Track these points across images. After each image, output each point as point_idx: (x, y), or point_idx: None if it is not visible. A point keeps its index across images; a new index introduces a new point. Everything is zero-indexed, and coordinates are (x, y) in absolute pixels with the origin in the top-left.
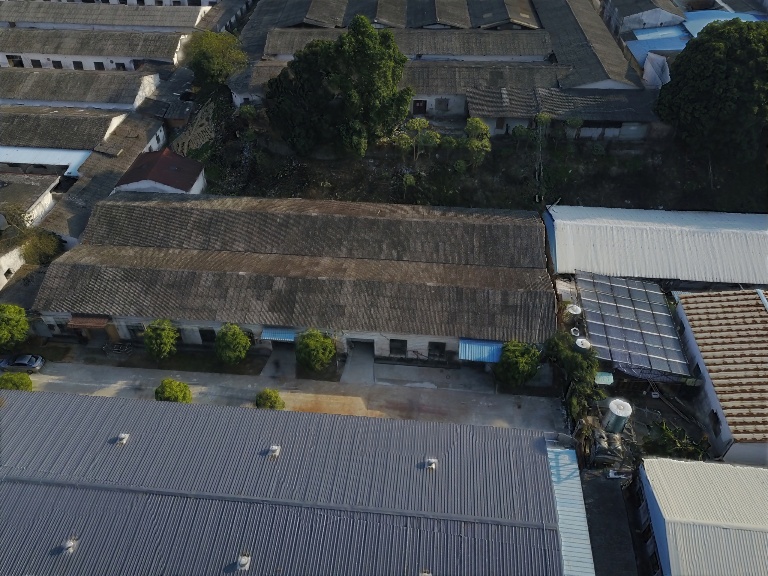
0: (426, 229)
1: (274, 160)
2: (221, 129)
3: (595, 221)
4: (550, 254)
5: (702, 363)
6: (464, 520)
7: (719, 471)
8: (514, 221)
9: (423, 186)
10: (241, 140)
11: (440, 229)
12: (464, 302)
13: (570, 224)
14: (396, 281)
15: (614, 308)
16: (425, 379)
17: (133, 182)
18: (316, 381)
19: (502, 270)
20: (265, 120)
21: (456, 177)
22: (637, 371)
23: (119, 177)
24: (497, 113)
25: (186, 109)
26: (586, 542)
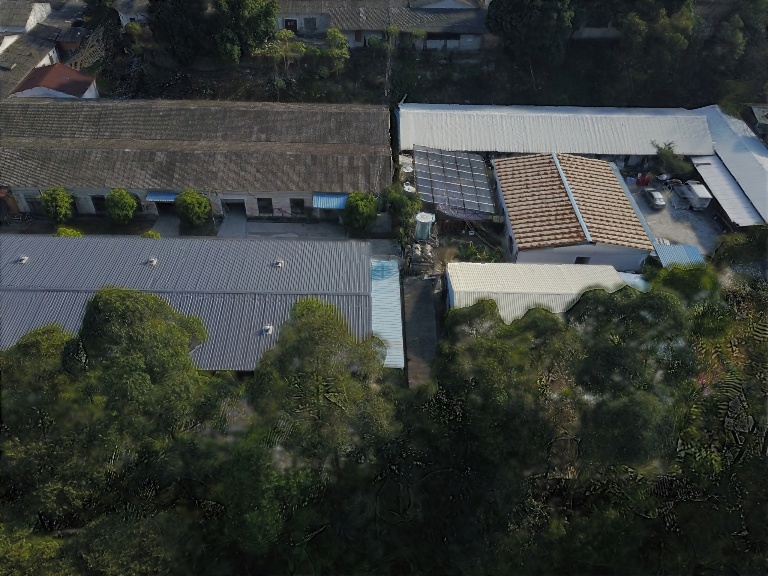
0: (291, 117)
1: (160, 72)
2: (110, 47)
3: (434, 111)
4: (398, 139)
5: (504, 203)
6: (300, 294)
7: (502, 266)
8: (365, 110)
9: (294, 91)
10: (129, 56)
11: (302, 117)
12: (317, 165)
13: (412, 112)
14: (261, 152)
15: (441, 170)
16: (289, 231)
17: (27, 89)
18: (196, 236)
19: (353, 145)
20: (150, 36)
21: (322, 83)
22: (455, 212)
23: (14, 87)
24: (354, 26)
25: (77, 33)
26: (398, 313)
